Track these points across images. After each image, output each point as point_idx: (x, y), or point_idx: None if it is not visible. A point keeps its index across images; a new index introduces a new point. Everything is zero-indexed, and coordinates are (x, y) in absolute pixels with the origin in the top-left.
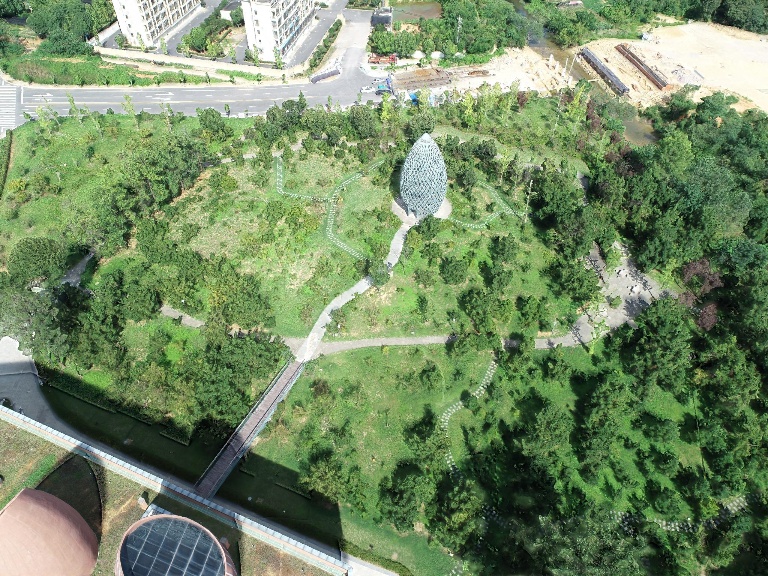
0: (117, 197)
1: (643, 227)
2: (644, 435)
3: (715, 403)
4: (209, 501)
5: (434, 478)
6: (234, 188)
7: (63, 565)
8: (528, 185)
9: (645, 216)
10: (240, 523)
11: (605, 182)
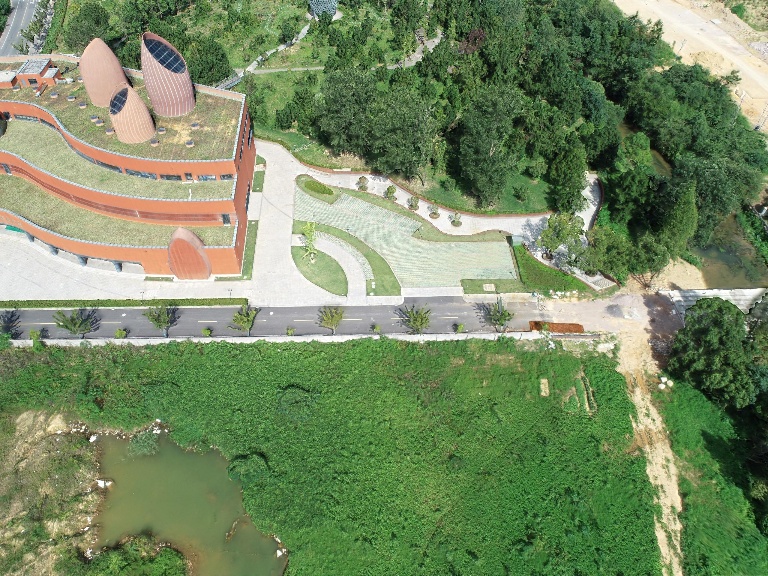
0: (138, 2)
1: None
2: (422, 99)
3: None
4: None
5: (305, 113)
6: (210, 10)
7: (118, 79)
8: None
9: None
10: (197, 88)
11: None
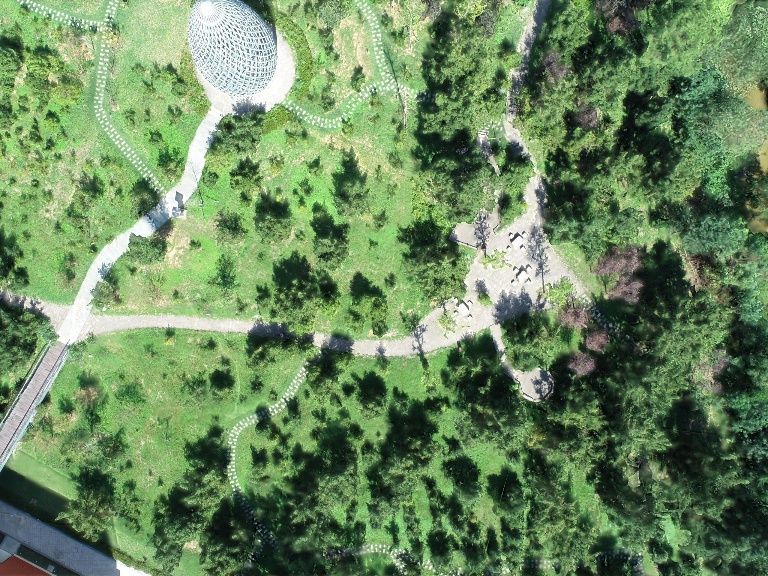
0: None
1: (573, 177)
2: None
3: (546, 455)
4: None
5: (211, 505)
6: None
7: None
8: (442, 11)
9: (589, 147)
10: None
11: (554, 60)
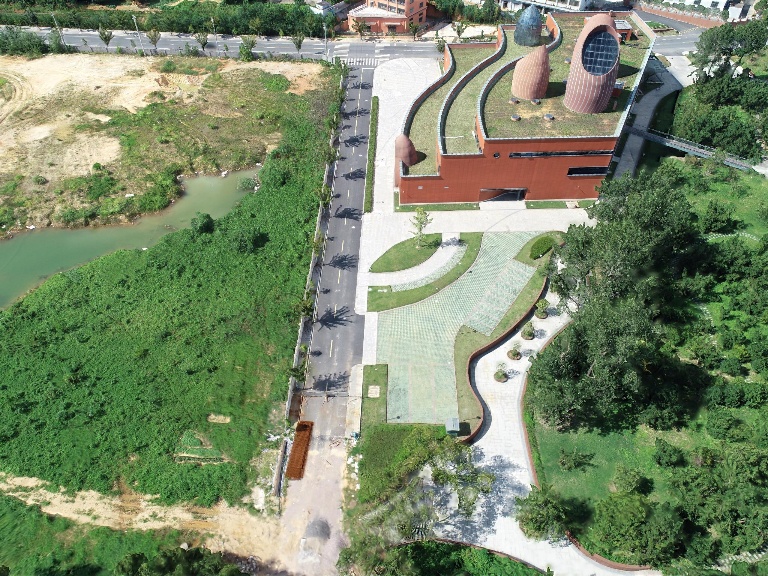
0: None
1: None
2: None
3: None
4: None
5: None
6: None
7: None
8: None
9: None
10: None
11: None
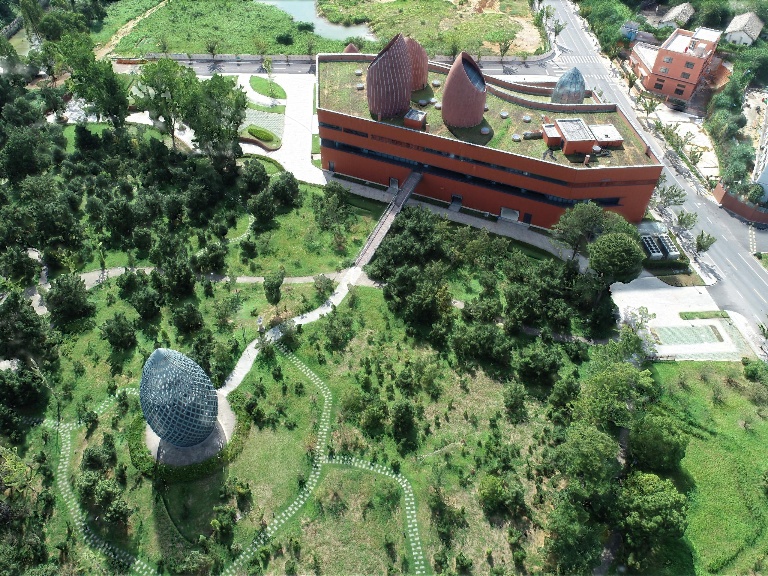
0: None
1: None
2: None
3: None
4: (391, 125)
5: None
6: None
7: None
8: None
9: None
10: None
11: None
